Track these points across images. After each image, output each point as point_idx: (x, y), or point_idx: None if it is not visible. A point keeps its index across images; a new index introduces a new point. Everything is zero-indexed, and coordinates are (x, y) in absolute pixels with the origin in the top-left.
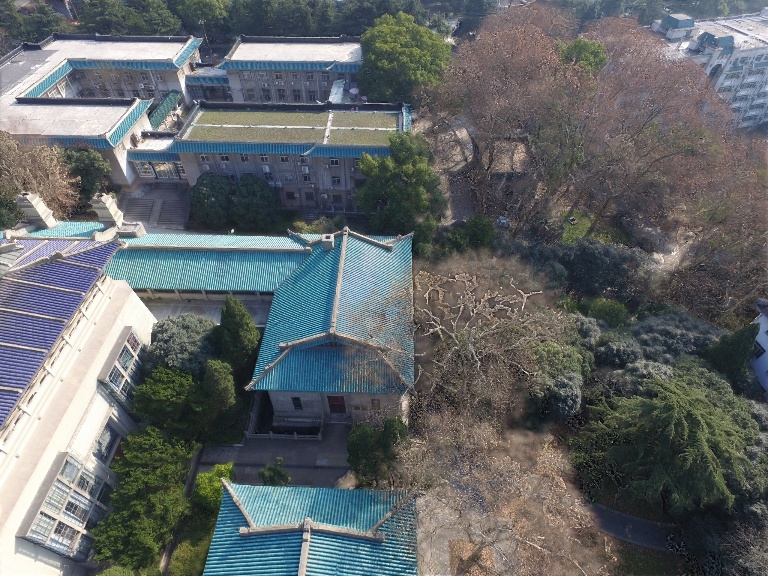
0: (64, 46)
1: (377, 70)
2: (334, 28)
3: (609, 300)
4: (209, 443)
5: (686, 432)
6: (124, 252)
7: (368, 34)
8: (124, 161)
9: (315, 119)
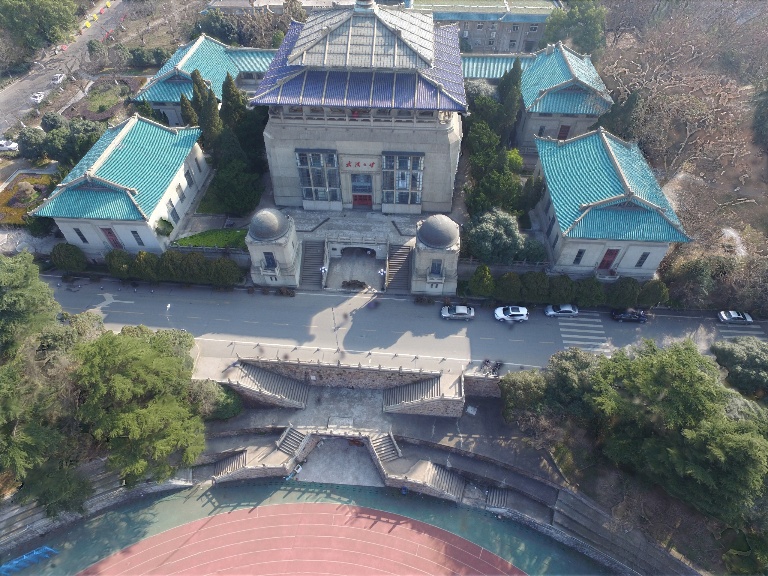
0: None
1: None
2: None
3: None
4: (498, 146)
5: None
6: None
7: None
8: None
9: (495, 2)
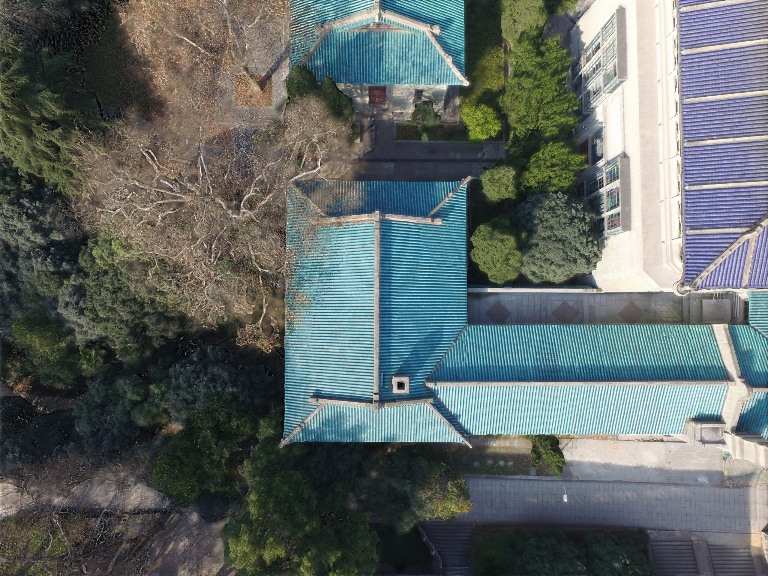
0: None
1: None
2: None
3: (28, 335)
4: (499, 161)
5: (1, 62)
6: (694, 376)
7: None
8: None
9: None
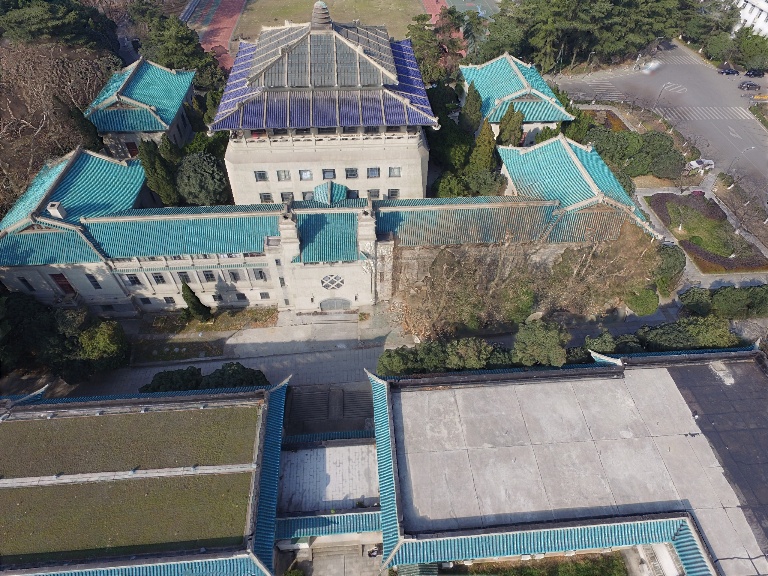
0: None
1: None
2: None
3: None
4: None
5: None
6: None
7: None
8: None
9: None
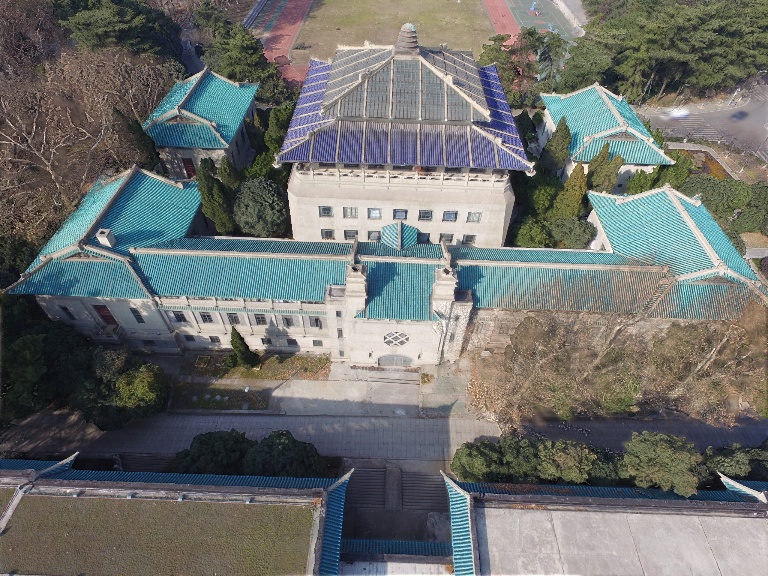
0: None
1: None
2: None
3: None
4: None
5: None
6: None
7: None
8: None
9: None
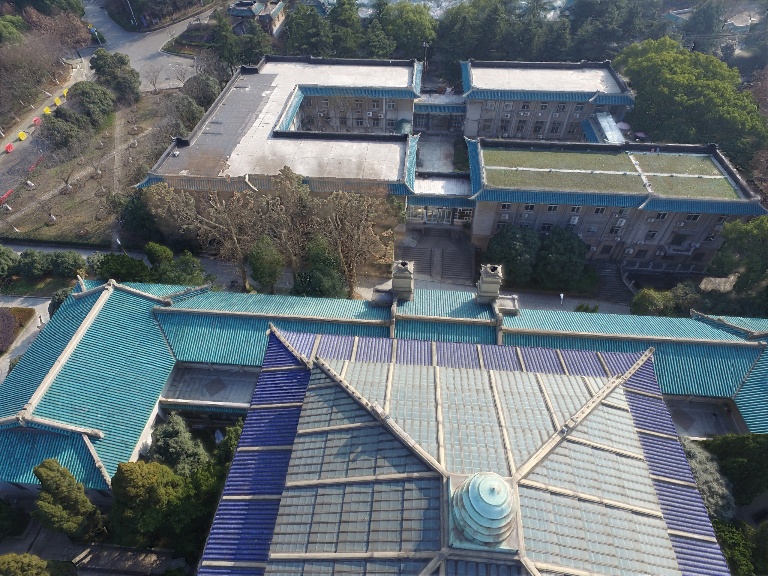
0: (280, 69)
1: (666, 104)
2: (567, 52)
3: None
4: None
5: None
6: (529, 338)
7: (644, 63)
8: (406, 206)
9: (618, 162)
